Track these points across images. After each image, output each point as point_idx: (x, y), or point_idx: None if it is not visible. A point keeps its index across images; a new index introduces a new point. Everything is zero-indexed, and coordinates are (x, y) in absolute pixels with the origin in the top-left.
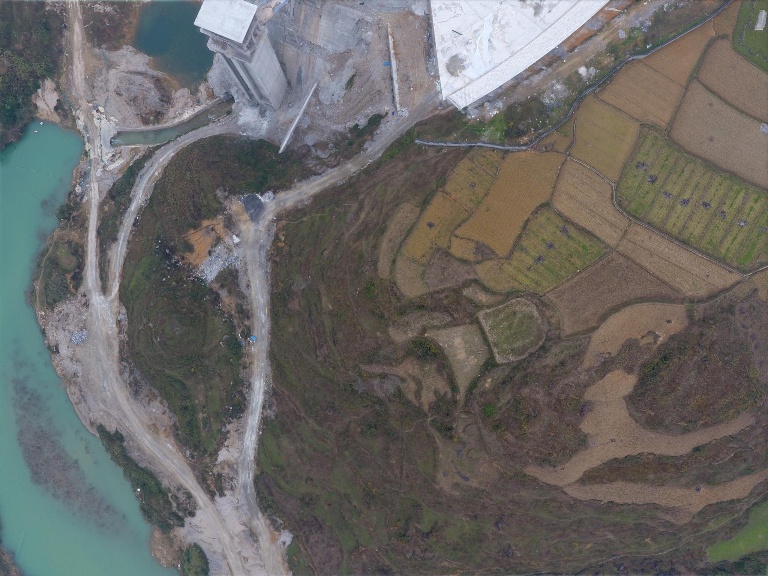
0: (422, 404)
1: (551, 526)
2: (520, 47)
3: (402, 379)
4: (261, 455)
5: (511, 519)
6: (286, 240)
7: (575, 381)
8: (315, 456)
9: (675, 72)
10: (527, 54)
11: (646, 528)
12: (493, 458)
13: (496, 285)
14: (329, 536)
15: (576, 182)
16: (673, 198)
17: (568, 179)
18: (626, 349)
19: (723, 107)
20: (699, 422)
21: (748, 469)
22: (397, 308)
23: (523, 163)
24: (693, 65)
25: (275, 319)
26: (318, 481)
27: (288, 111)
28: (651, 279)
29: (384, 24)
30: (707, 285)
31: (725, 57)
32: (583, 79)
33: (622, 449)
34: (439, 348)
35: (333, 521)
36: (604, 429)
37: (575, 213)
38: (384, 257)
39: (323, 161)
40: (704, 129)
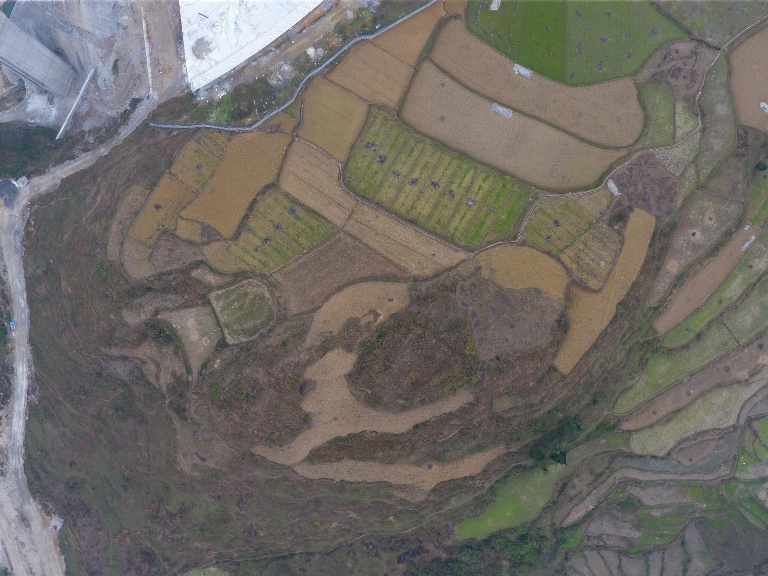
0: (160, 386)
1: (289, 505)
2: (266, 29)
3: (142, 361)
4: (28, 440)
5: (249, 499)
6: (35, 225)
7: (295, 360)
8: (76, 440)
9: (404, 52)
10: (266, 36)
11: (385, 506)
12: (221, 438)
13: (223, 266)
14: (97, 520)
15: (304, 163)
16: (402, 178)
17: (296, 160)
18: (345, 328)
19: (455, 87)
20: (415, 399)
21: (479, 446)
22: (126, 290)
23: (249, 144)
24: (422, 45)
25: (30, 304)
26: (81, 465)
27: (75, 98)
28: (378, 259)
29: (138, 8)
30: (433, 264)
31: (458, 37)
32: (311, 60)
33: (344, 427)
34: (172, 330)
35: (98, 505)
36: (326, 408)
37: (302, 194)
38: (114, 239)
39: (86, 146)
40: (435, 109)
